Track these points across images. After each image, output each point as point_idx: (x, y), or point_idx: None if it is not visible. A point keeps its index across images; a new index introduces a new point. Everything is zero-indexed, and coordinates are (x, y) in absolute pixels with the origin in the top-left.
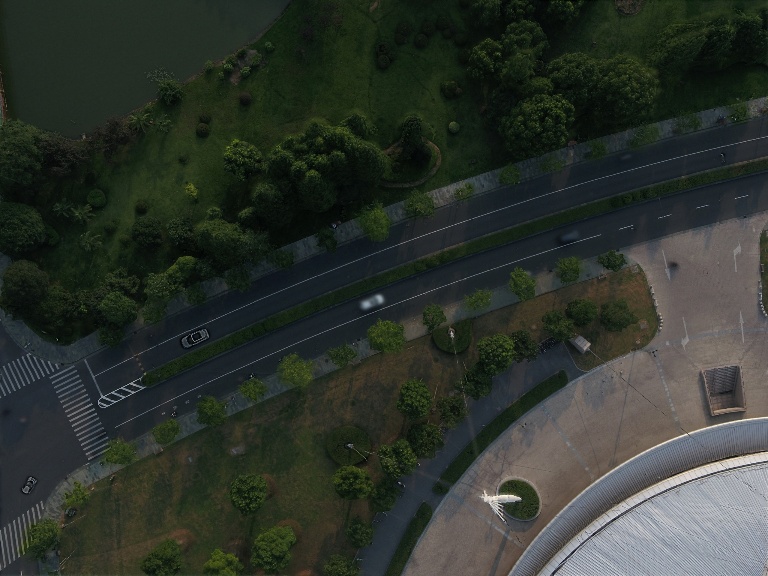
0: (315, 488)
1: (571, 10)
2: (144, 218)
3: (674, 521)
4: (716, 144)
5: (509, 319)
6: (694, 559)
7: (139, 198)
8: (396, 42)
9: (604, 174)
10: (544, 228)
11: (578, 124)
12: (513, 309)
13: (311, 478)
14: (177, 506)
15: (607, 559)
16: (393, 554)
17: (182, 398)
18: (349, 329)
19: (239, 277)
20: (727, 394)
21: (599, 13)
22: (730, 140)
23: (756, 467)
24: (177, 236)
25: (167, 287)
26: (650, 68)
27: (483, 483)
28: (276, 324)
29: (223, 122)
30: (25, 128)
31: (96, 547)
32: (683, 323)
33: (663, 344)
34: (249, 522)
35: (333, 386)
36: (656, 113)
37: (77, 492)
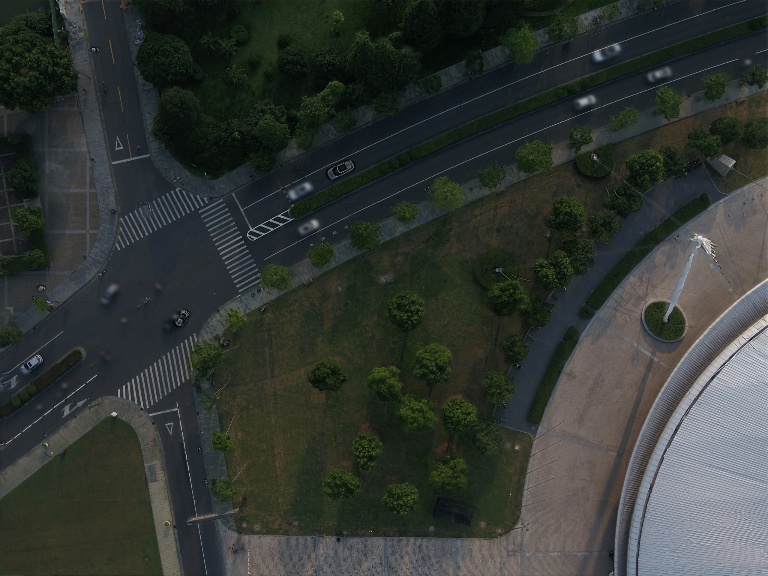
0: (463, 314)
1: None
2: (290, 48)
3: None
4: None
5: (650, 144)
6: None
7: (281, 33)
8: None
9: None
10: (683, 52)
11: None
12: (653, 134)
13: (459, 304)
14: (329, 334)
15: (767, 360)
16: (541, 378)
17: (329, 229)
18: (492, 157)
19: (390, 99)
20: None
21: None
22: None
23: None
24: (326, 62)
25: (322, 108)
26: None
27: (628, 306)
28: (421, 153)
29: None
30: None
31: (250, 377)
32: None
33: None
34: (400, 348)
35: (478, 214)
36: None
37: None
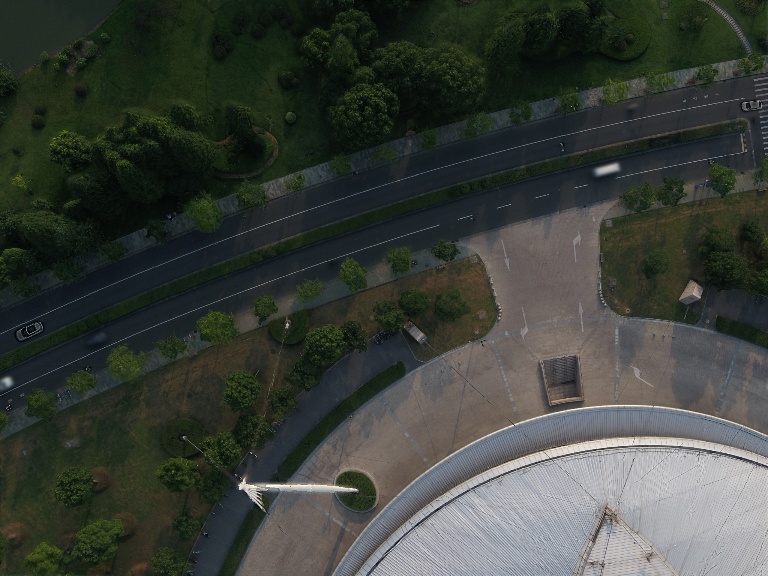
0: (151, 481)
1: None
2: None
3: (495, 511)
4: (555, 133)
5: (347, 310)
6: (511, 548)
7: None
8: (233, 32)
9: (443, 164)
10: (381, 218)
11: (416, 114)
12: (351, 300)
13: (146, 471)
14: (11, 500)
15: (428, 549)
16: (230, 546)
17: (17, 391)
18: (185, 321)
19: (65, 269)
20: (569, 384)
21: (437, 2)
22: (569, 129)
23: (579, 456)
24: (4, 228)
25: None
26: (488, 57)
27: (321, 475)
28: (110, 316)
29: (59, 113)
30: None
31: None
32: (522, 313)
33: (502, 334)
34: (84, 515)
35: (169, 378)
36: (495, 103)
37: None
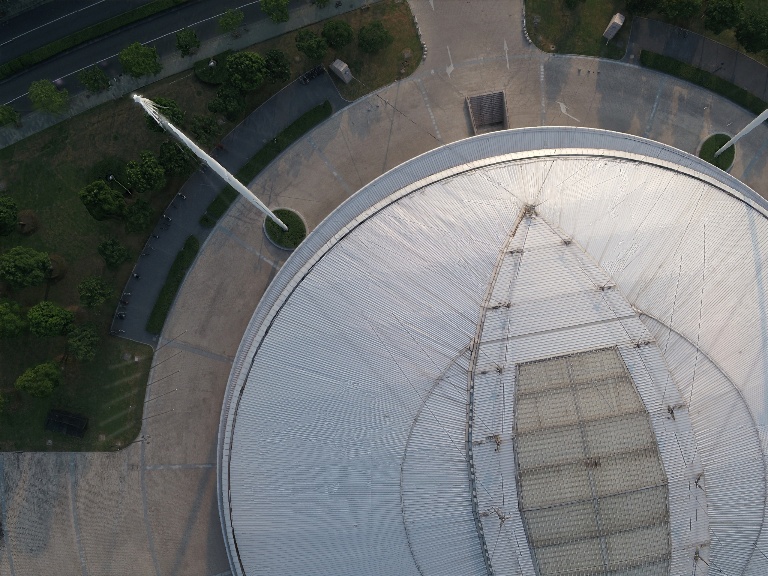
0: (79, 223)
1: None
2: None
3: (417, 218)
4: None
5: None
6: (433, 249)
7: None
8: None
9: None
10: None
11: None
12: (276, 42)
13: (75, 213)
14: None
15: (352, 258)
16: (161, 288)
17: None
18: (110, 64)
19: None
20: (498, 126)
21: None
22: None
23: (501, 166)
24: None
25: None
26: None
27: (251, 215)
28: (34, 59)
29: None
30: None
31: None
32: (447, 51)
33: (428, 73)
34: None
35: (95, 121)
36: None
37: None
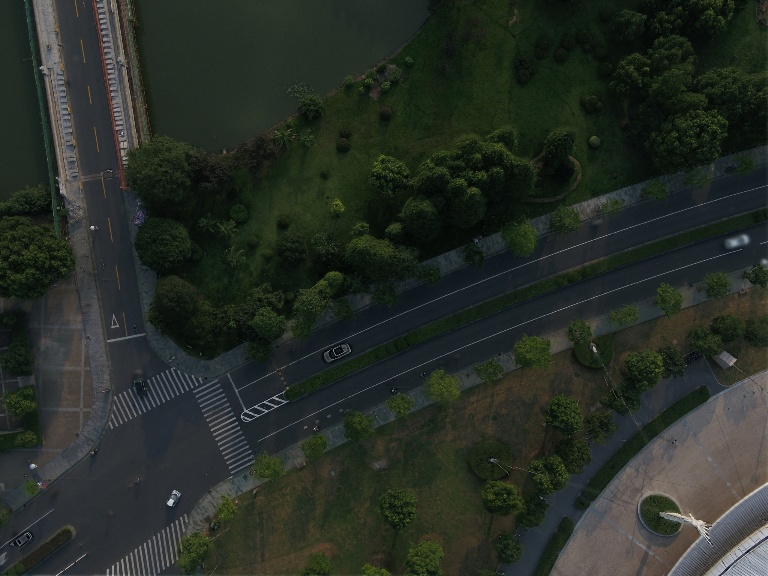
0: (457, 502)
1: (722, 25)
2: (290, 233)
3: None
4: None
5: (650, 334)
6: None
7: (280, 213)
8: (536, 56)
9: (745, 188)
10: (686, 243)
11: None
12: (654, 324)
13: (453, 492)
14: (320, 520)
15: None
16: (534, 568)
17: (324, 412)
18: (490, 344)
19: (388, 293)
20: None
21: (740, 26)
22: None
23: None
24: (325, 251)
25: (319, 303)
26: None
27: (624, 498)
28: (418, 339)
29: (363, 137)
30: (175, 144)
31: (240, 560)
32: None
33: None
34: (392, 536)
35: (474, 401)
36: None
37: None
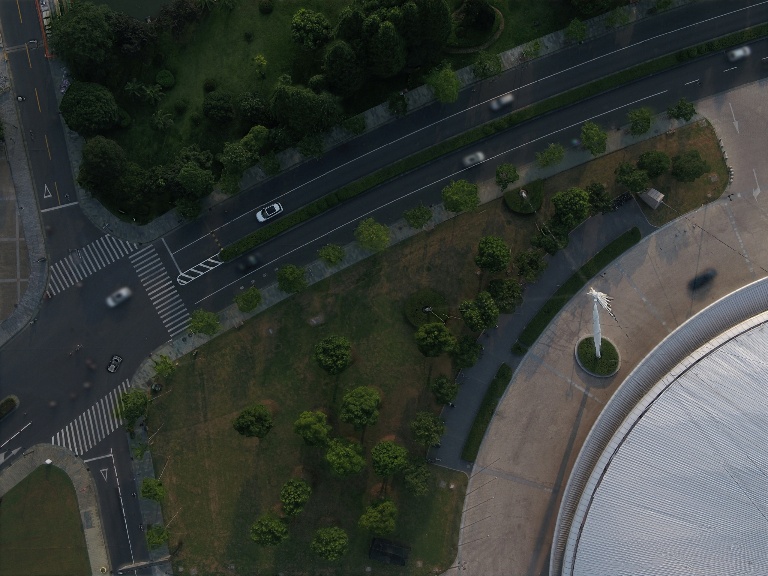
0: (395, 354)
1: None
2: (215, 92)
3: (760, 357)
4: None
5: (579, 179)
6: None
7: (207, 77)
8: None
9: (667, 30)
10: (610, 86)
11: None
12: (583, 169)
13: (391, 344)
14: (260, 377)
15: (695, 398)
16: (475, 416)
17: (259, 272)
18: (421, 196)
19: (313, 143)
20: None
21: None
22: None
23: None
24: (249, 106)
25: (244, 154)
26: None
27: (561, 342)
28: (349, 193)
29: None
30: (94, 7)
31: (183, 421)
32: (754, 174)
33: (735, 196)
34: (332, 390)
35: (408, 253)
36: None
37: (164, 363)
